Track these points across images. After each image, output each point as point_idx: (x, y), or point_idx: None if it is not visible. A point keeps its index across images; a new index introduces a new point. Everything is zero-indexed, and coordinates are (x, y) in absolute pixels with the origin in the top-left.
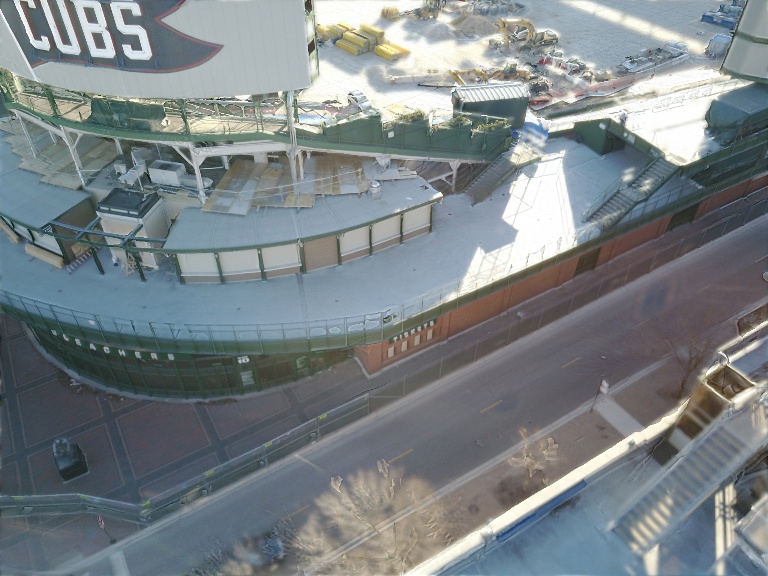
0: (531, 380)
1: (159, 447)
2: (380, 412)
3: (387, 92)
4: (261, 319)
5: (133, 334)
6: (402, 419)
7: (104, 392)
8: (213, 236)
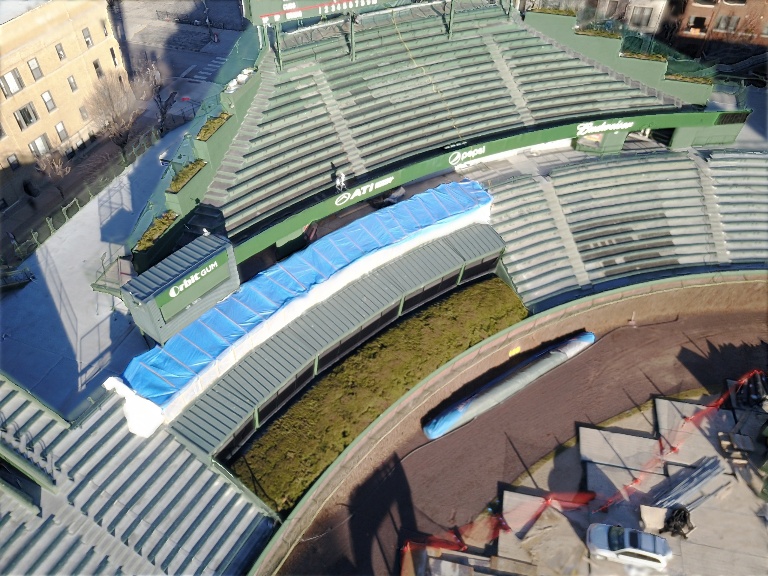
0: None
1: None
2: None
3: None
4: None
5: None
6: None
7: None
8: None
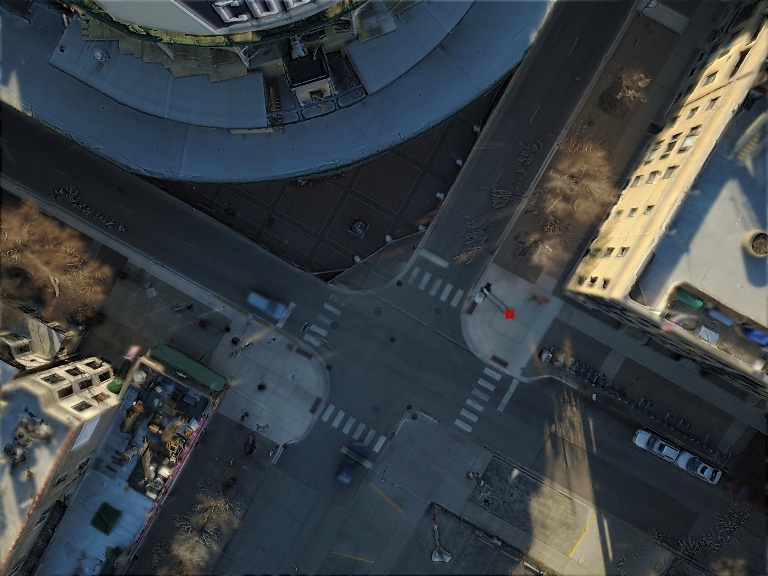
0: (591, 10)
1: (394, 189)
2: (506, 91)
3: None
4: (441, 95)
5: (374, 153)
6: (522, 88)
7: (327, 177)
8: (391, 64)
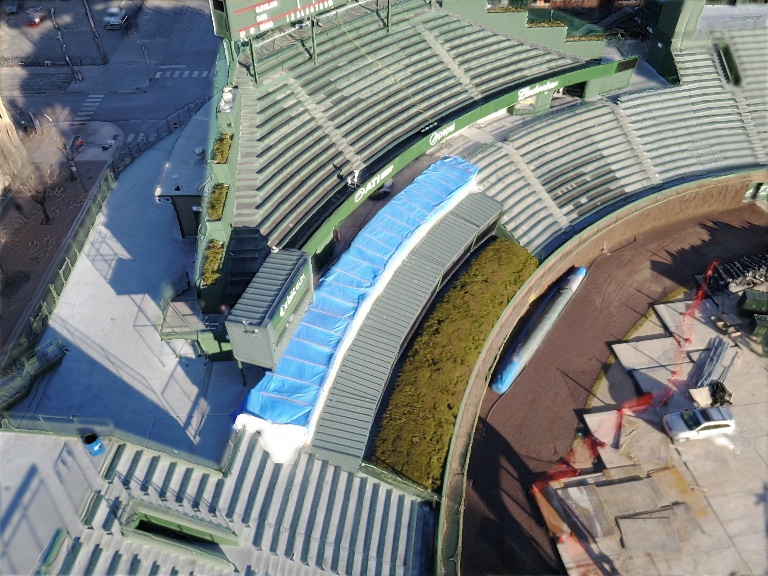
0: None
1: None
2: None
3: (765, 503)
4: None
5: None
6: None
7: None
8: None
